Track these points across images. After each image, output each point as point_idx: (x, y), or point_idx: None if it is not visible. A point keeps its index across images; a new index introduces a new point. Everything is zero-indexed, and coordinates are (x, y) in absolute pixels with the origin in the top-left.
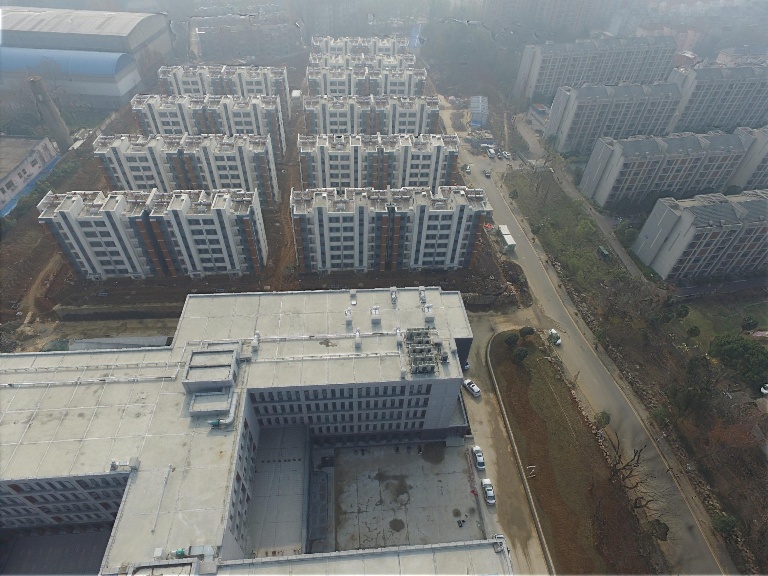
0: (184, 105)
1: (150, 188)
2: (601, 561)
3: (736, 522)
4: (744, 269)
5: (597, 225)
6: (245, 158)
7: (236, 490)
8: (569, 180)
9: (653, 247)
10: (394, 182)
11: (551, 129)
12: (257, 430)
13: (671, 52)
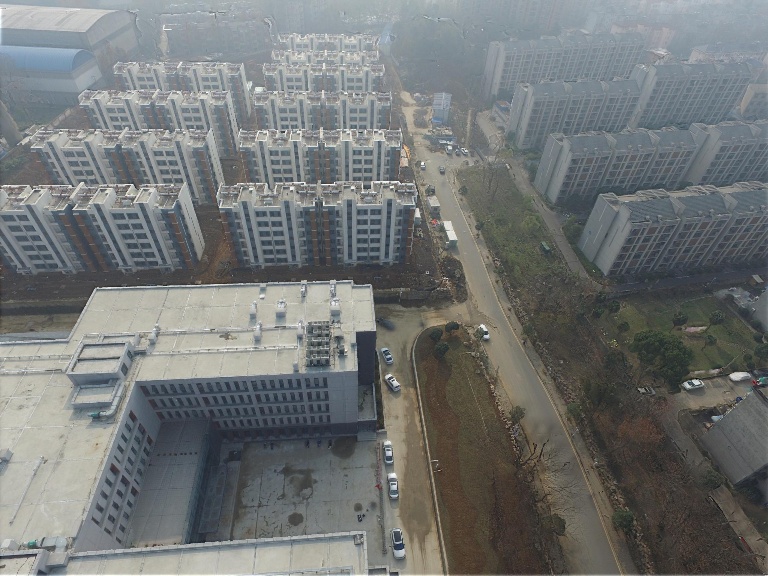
0: (131, 100)
1: (91, 183)
2: (494, 555)
3: (637, 517)
4: (688, 265)
5: (544, 221)
6: (184, 153)
7: (112, 482)
8: (525, 176)
9: (595, 243)
10: (338, 178)
11: (511, 126)
12: (156, 423)
13: (638, 49)
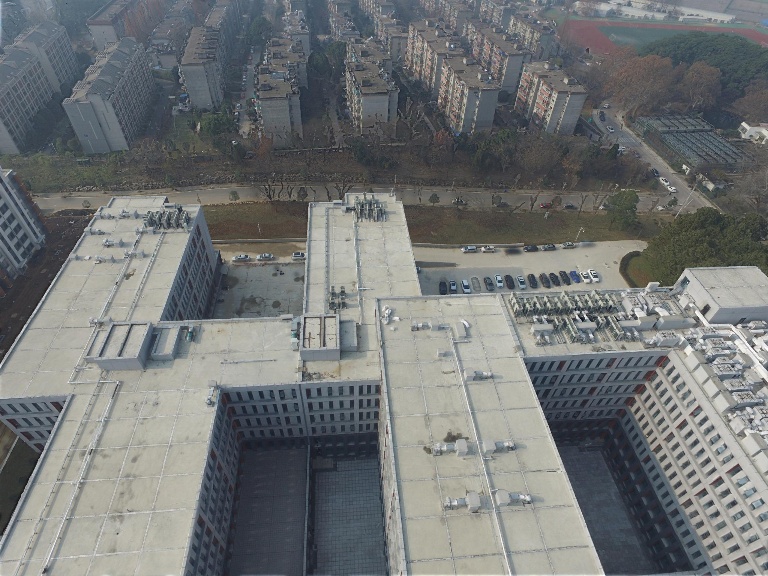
0: None
1: None
2: None
3: None
4: (141, 118)
5: None
6: None
7: None
8: None
9: (98, 137)
10: None
11: None
12: None
13: None
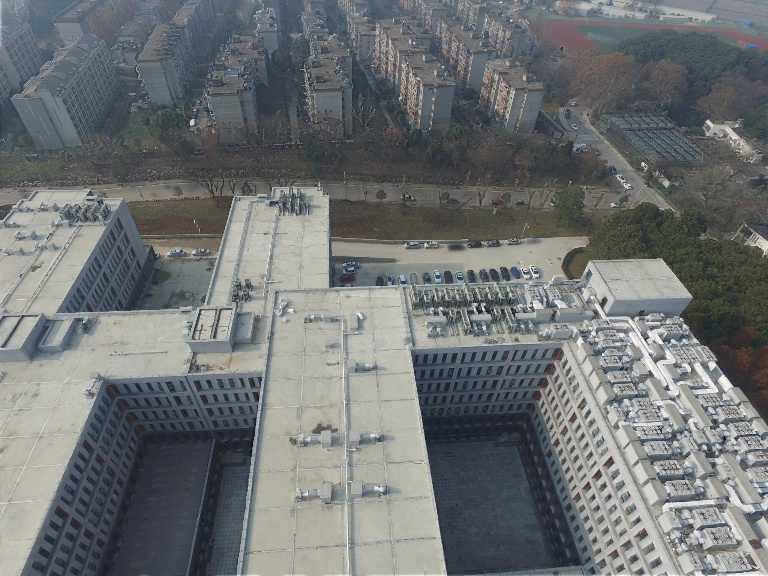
0: None
1: None
2: None
3: None
4: (100, 114)
5: None
6: None
7: None
8: None
9: (50, 133)
10: None
11: None
12: None
13: None
